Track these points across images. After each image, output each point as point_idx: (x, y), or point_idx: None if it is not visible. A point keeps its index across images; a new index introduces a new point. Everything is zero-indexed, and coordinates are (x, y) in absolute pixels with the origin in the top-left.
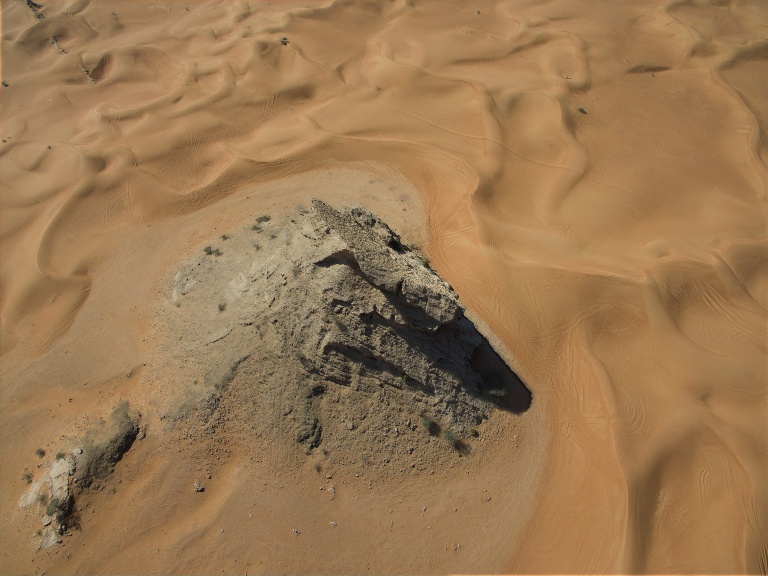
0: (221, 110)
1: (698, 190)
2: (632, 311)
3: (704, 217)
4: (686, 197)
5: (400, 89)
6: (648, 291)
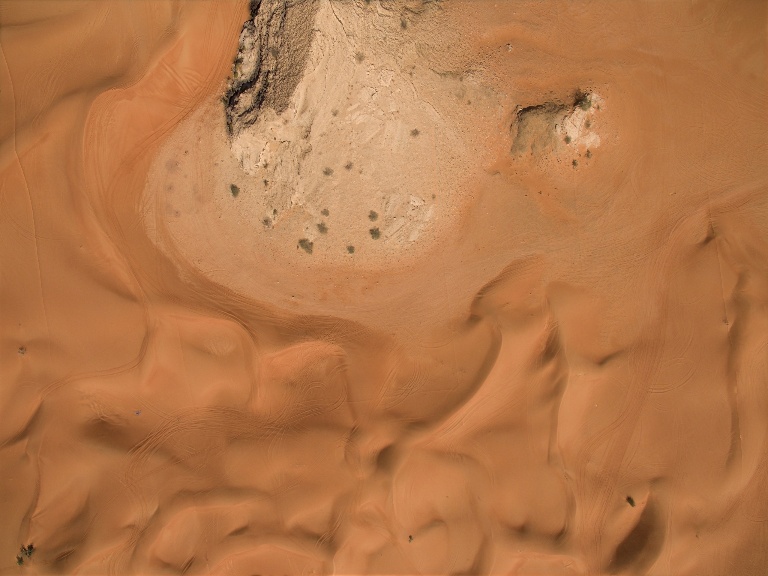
0: (211, 472)
1: None
2: None
3: None
4: None
5: (3, 324)
6: None
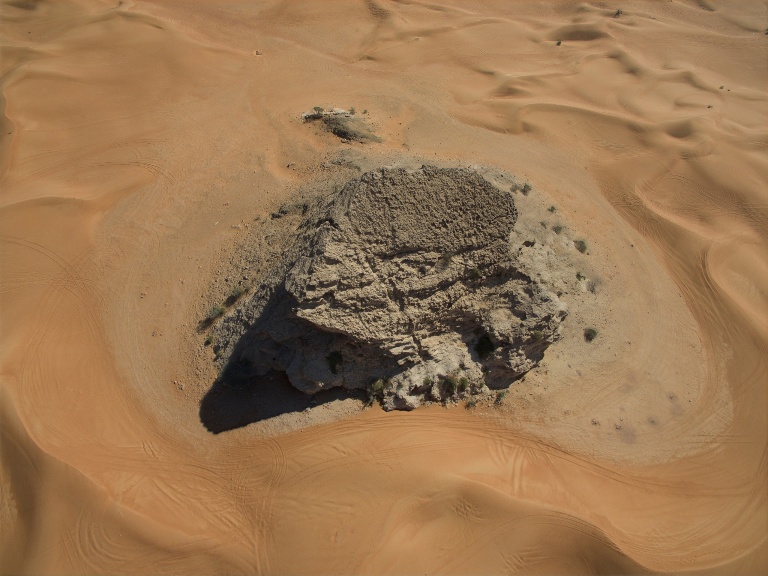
0: None
1: None
2: None
3: None
4: None
5: None
6: None
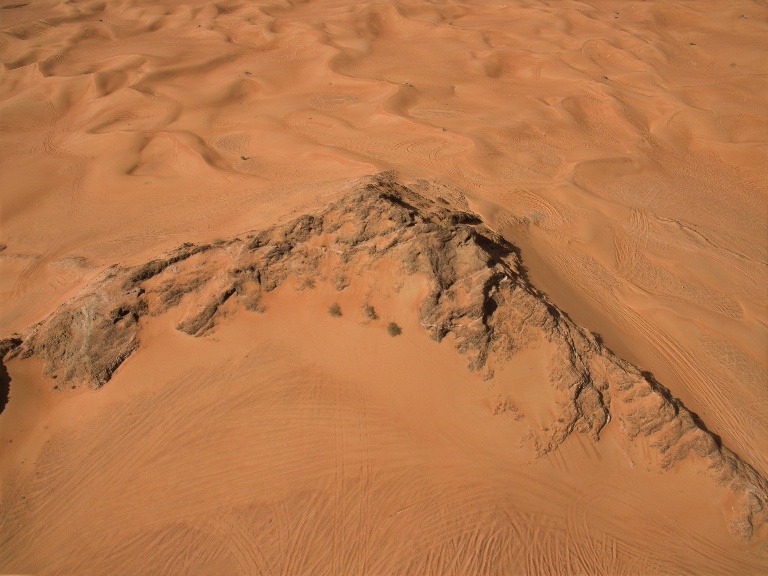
0: None
1: None
2: (0, 42)
3: None
4: None
5: None
6: (2, 33)
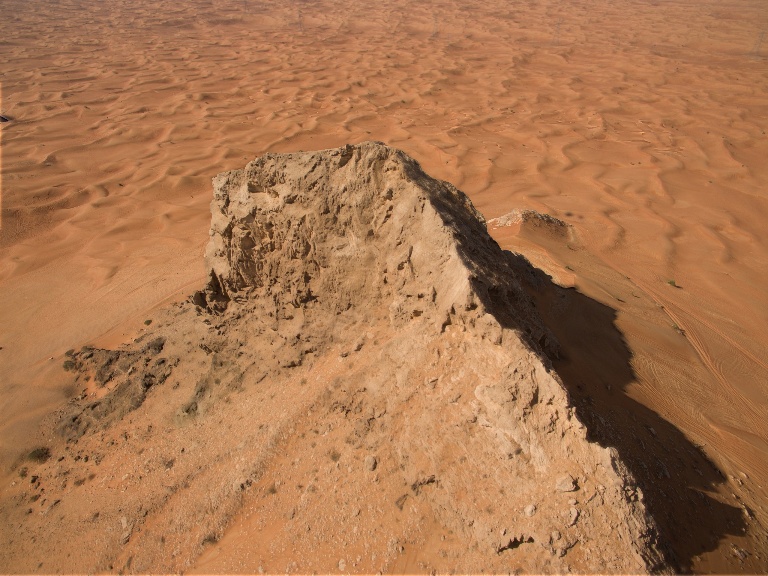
0: None
1: None
2: None
3: None
4: None
5: None
6: (43, 106)
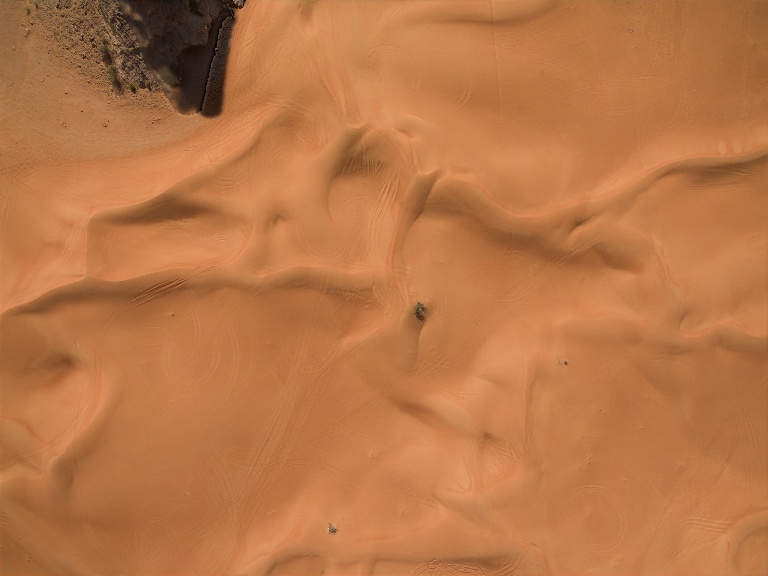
0: None
1: (562, 139)
2: (320, 136)
3: (508, 154)
4: (539, 131)
5: None
6: (342, 134)
